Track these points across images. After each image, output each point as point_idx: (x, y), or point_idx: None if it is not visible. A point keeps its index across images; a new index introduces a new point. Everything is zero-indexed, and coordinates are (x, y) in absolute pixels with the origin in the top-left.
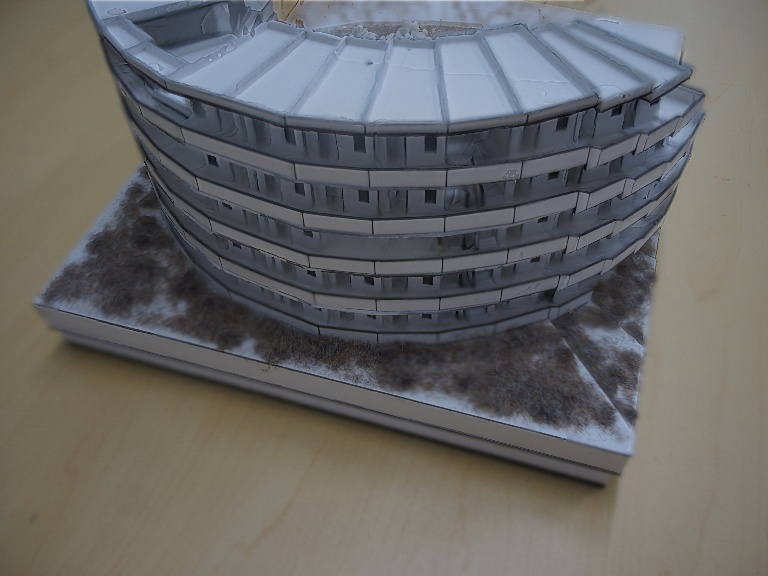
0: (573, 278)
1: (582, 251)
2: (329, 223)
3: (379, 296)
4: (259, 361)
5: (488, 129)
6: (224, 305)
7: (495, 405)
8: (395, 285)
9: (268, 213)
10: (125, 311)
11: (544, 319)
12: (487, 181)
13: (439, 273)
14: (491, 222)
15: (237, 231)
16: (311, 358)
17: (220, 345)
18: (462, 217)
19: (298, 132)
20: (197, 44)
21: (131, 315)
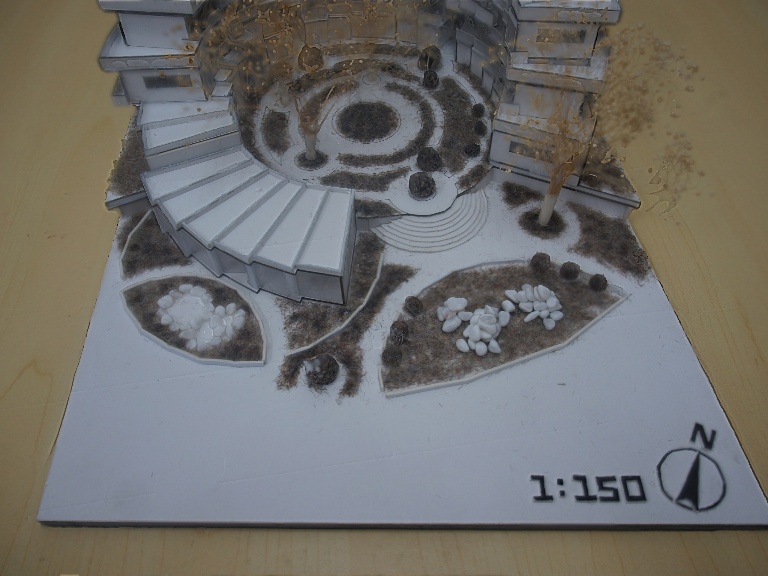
0: None
1: None
2: None
3: None
4: None
5: None
6: None
7: None
8: None
9: None
10: None
11: None
12: None
13: None
14: None
15: None
16: None
17: None
18: None
19: None
20: None
21: None
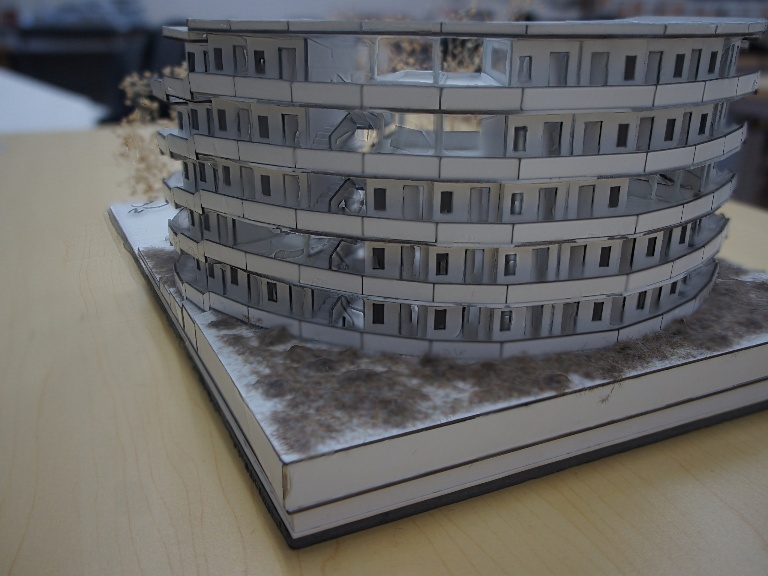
0: None
1: None
2: (664, 160)
3: None
4: (604, 384)
5: (757, 33)
6: (504, 363)
7: None
8: None
9: (605, 173)
10: (416, 413)
11: None
12: (747, 91)
13: (710, 211)
14: (736, 144)
15: (554, 222)
16: (637, 361)
17: (558, 387)
18: (730, 136)
19: (641, 60)
20: (393, 73)
21: (428, 413)
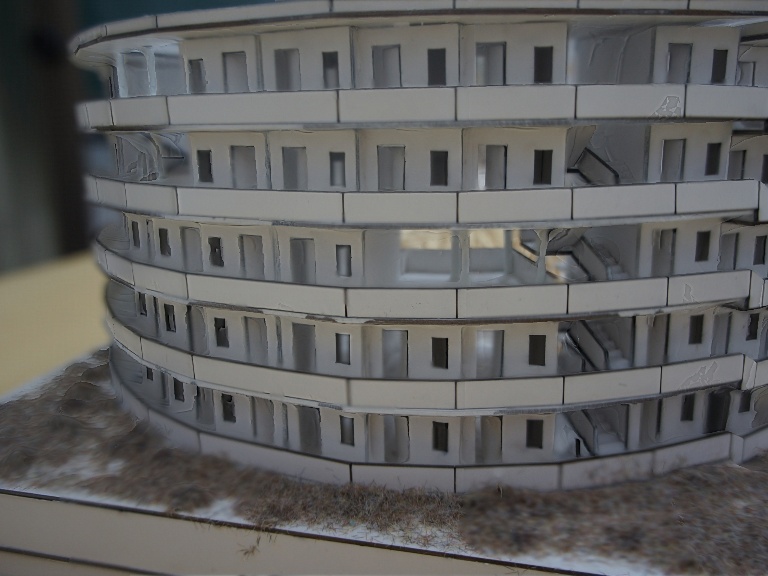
0: (761, 370)
1: (753, 351)
2: (385, 209)
3: (459, 379)
4: (241, 525)
5: (635, 11)
6: (188, 458)
7: (707, 564)
8: (481, 374)
9: (285, 217)
10: (16, 472)
11: (724, 458)
12: (636, 115)
13: (562, 315)
14: (642, 208)
15: (229, 279)
16: (337, 516)
17: (172, 503)
18: (598, 191)
19: (344, 58)
20: None
21: (25, 477)
